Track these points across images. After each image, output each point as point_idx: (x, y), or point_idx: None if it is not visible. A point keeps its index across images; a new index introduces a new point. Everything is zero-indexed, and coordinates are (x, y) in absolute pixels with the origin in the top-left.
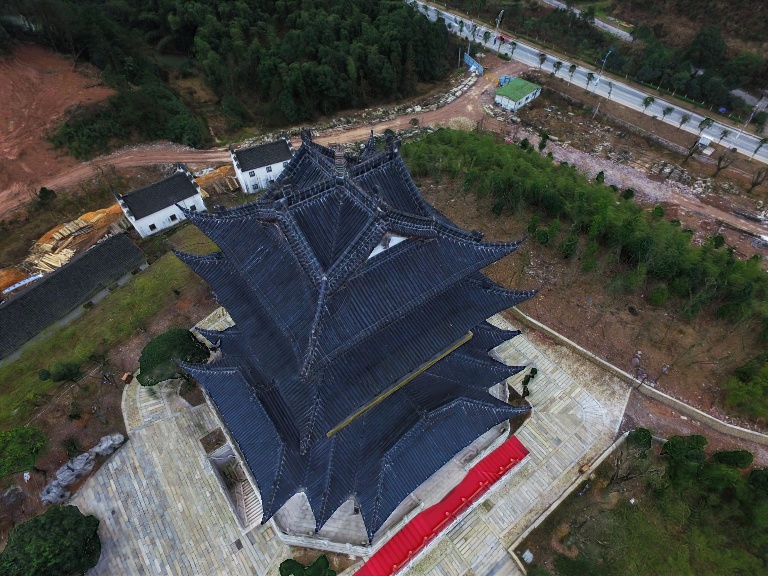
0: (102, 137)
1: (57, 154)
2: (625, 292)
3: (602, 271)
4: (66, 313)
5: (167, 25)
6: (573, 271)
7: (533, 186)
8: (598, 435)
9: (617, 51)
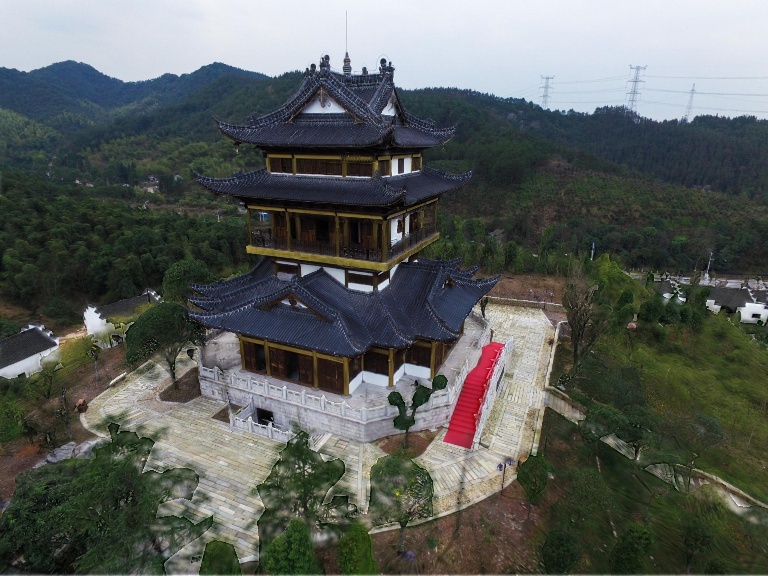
0: None
1: None
2: (498, 273)
3: None
4: None
5: None
6: None
7: None
8: (544, 329)
9: None
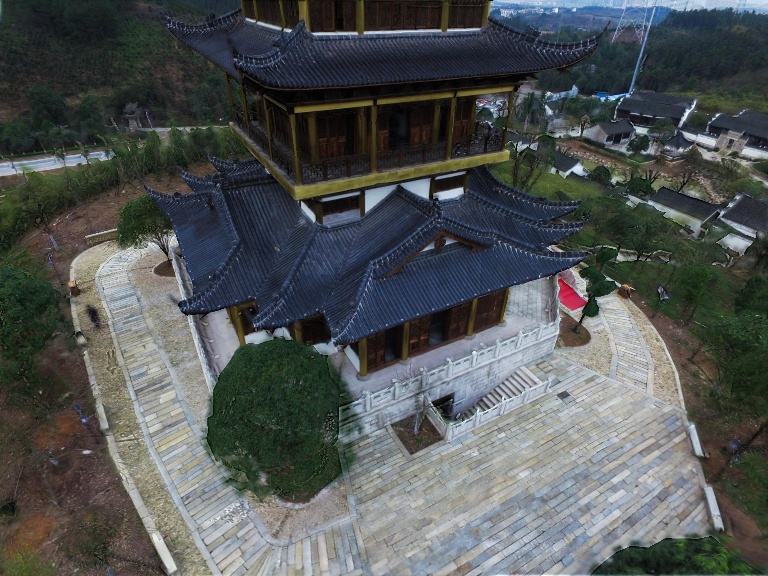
0: None
1: None
2: None
3: None
4: None
5: None
6: None
7: None
8: None
9: None
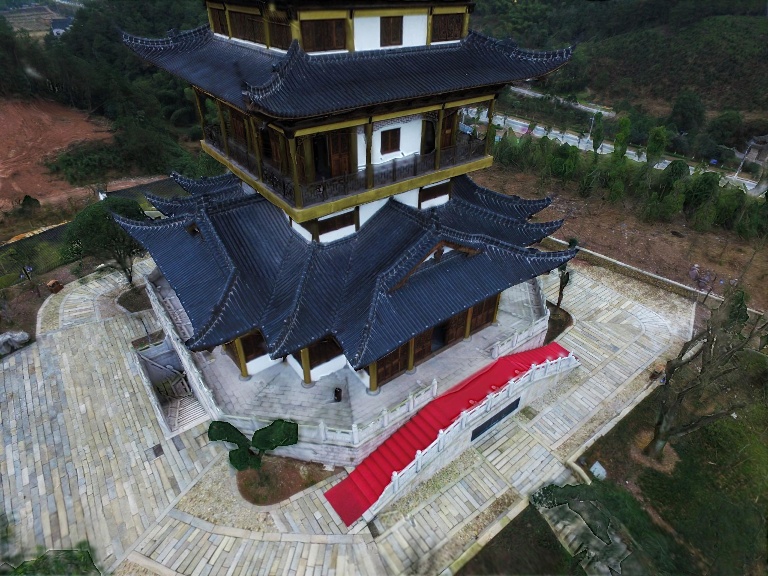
0: (101, 167)
1: (52, 178)
2: (663, 221)
3: (631, 207)
4: (13, 283)
5: (183, 100)
6: (598, 205)
7: (542, 139)
8: (666, 343)
9: (603, 120)
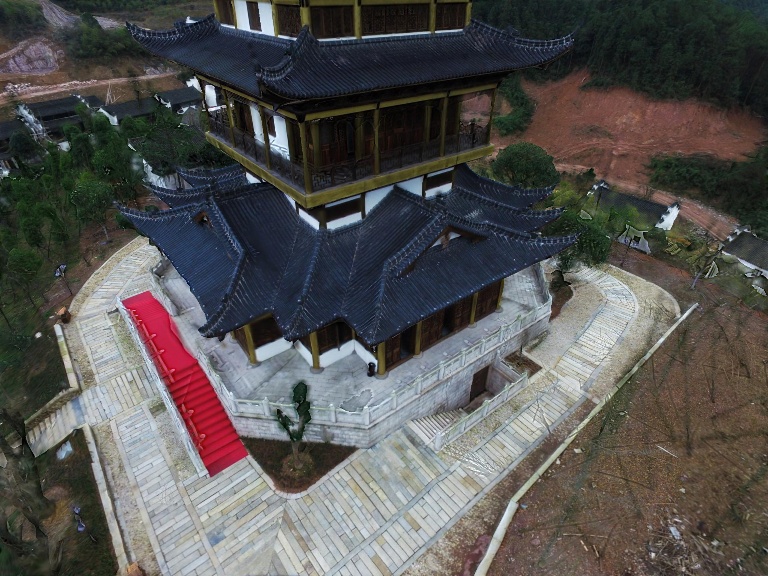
0: (689, 182)
1: (643, 171)
2: None
3: None
4: None
5: None
6: None
7: None
8: None
9: None
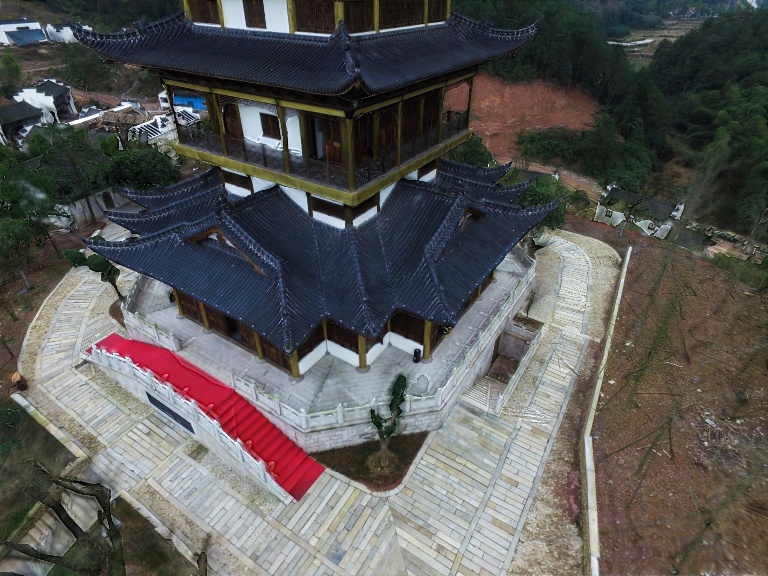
0: (552, 152)
1: (514, 147)
2: None
3: None
4: None
5: None
6: None
7: None
8: None
9: None
